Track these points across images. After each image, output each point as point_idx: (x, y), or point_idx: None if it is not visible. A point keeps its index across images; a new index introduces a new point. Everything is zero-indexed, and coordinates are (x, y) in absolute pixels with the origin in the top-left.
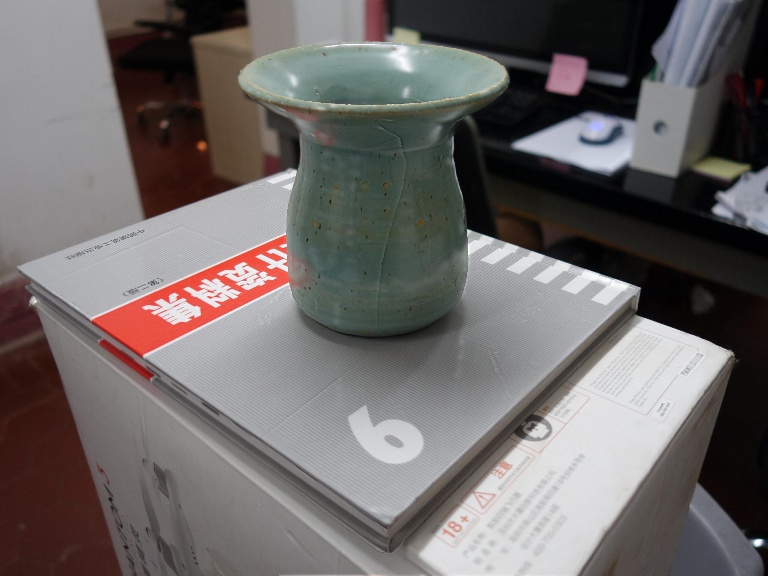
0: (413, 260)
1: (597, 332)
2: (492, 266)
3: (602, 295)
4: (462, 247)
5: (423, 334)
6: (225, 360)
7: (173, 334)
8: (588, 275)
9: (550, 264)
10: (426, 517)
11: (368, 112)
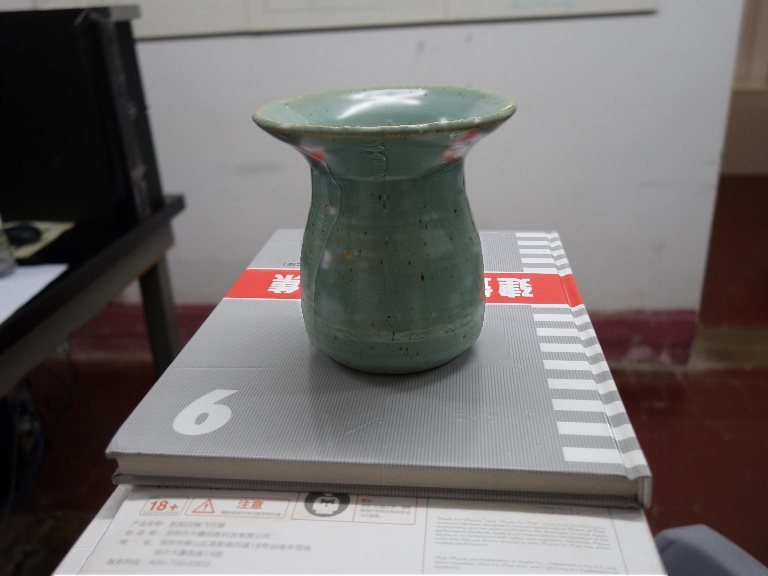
0: (337, 289)
1: (529, 483)
2: (541, 369)
3: (584, 451)
4: (412, 304)
5: (367, 378)
6: (244, 322)
7: (256, 295)
8: (622, 430)
9: (608, 400)
10: (160, 484)
11: (265, 125)
